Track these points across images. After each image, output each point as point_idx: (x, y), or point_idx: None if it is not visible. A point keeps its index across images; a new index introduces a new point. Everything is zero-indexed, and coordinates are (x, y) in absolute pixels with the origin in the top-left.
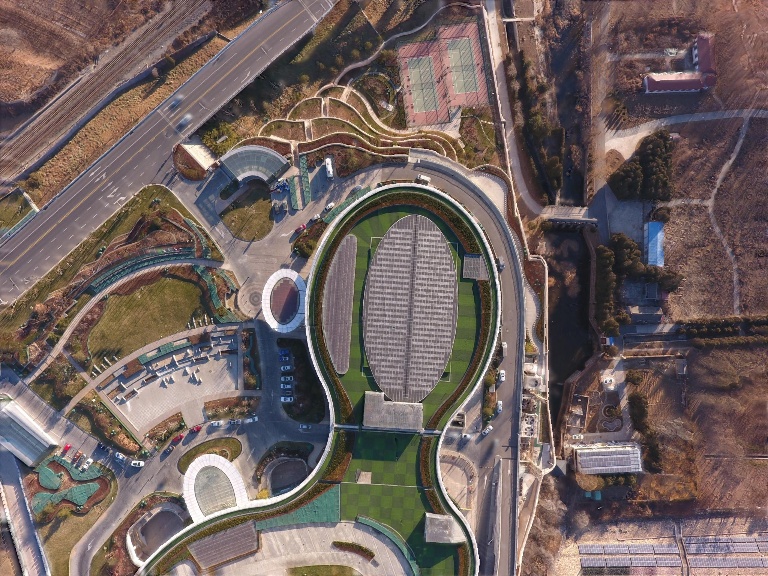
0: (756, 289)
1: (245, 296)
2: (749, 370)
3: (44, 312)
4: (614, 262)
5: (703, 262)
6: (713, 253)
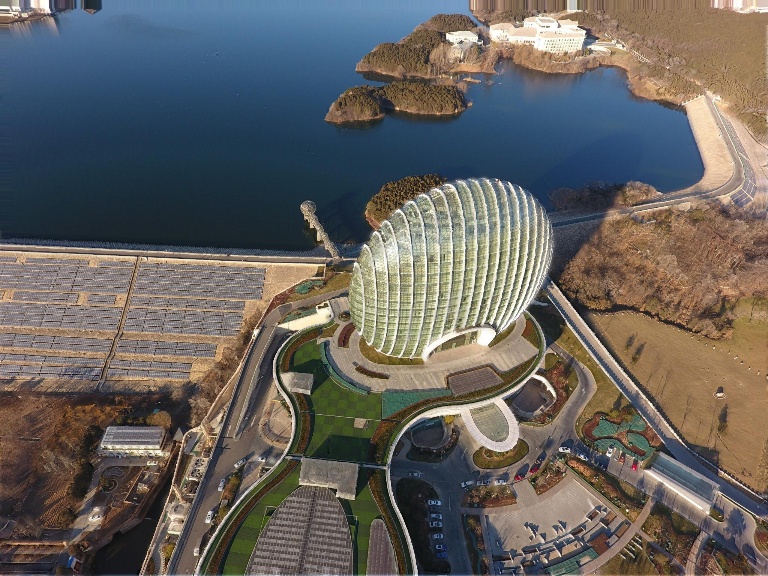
0: None
1: None
2: None
3: None
4: None
5: None
6: None
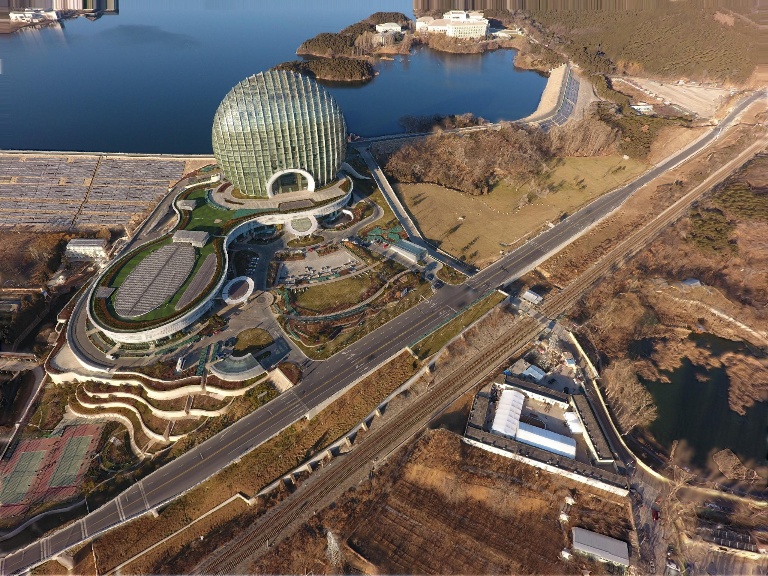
0: None
1: (268, 302)
2: None
3: None
4: None
5: None
6: None
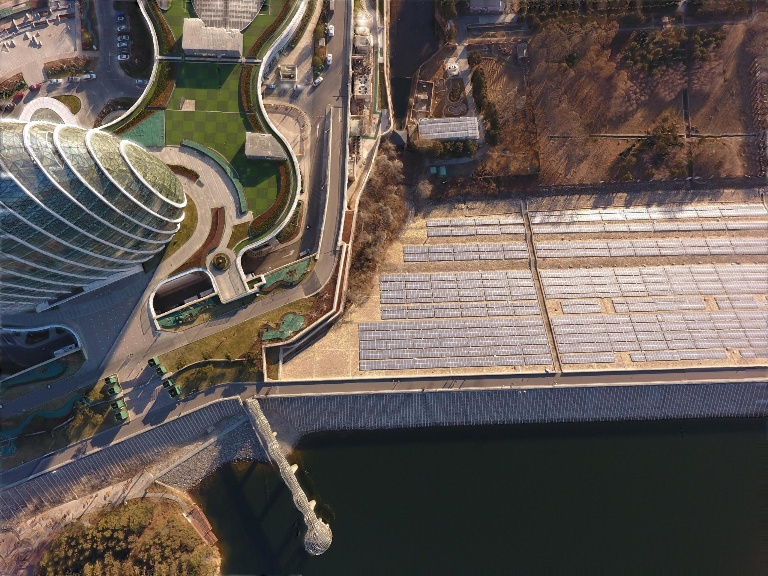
0: None
1: None
2: (579, 34)
3: None
4: None
5: None
6: None
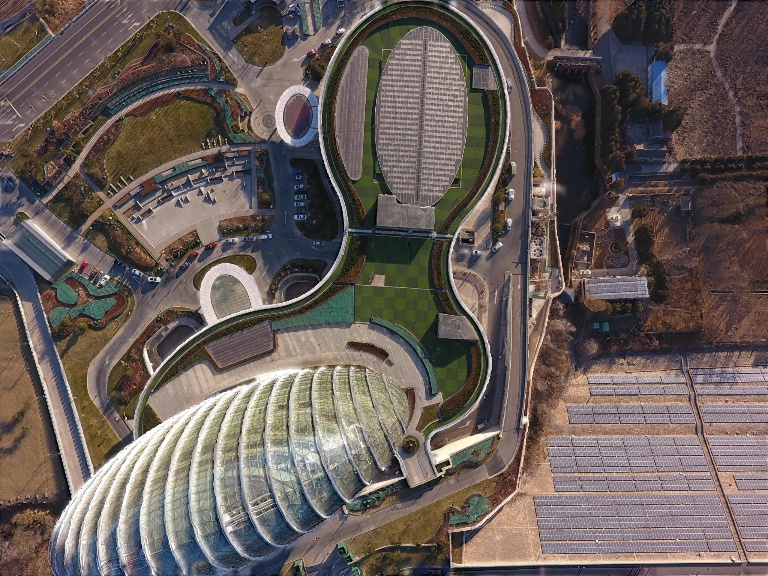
0: (758, 131)
1: (258, 119)
2: (753, 197)
3: (61, 132)
4: (619, 98)
5: (706, 105)
6: (716, 96)
